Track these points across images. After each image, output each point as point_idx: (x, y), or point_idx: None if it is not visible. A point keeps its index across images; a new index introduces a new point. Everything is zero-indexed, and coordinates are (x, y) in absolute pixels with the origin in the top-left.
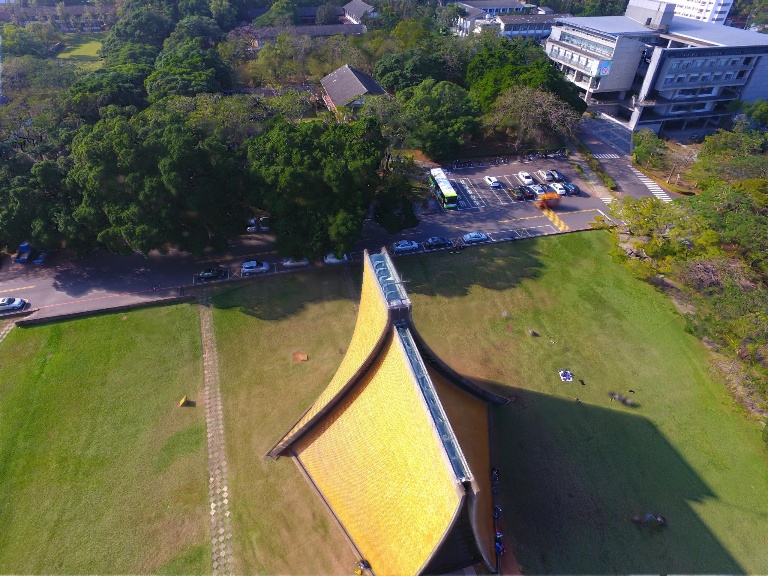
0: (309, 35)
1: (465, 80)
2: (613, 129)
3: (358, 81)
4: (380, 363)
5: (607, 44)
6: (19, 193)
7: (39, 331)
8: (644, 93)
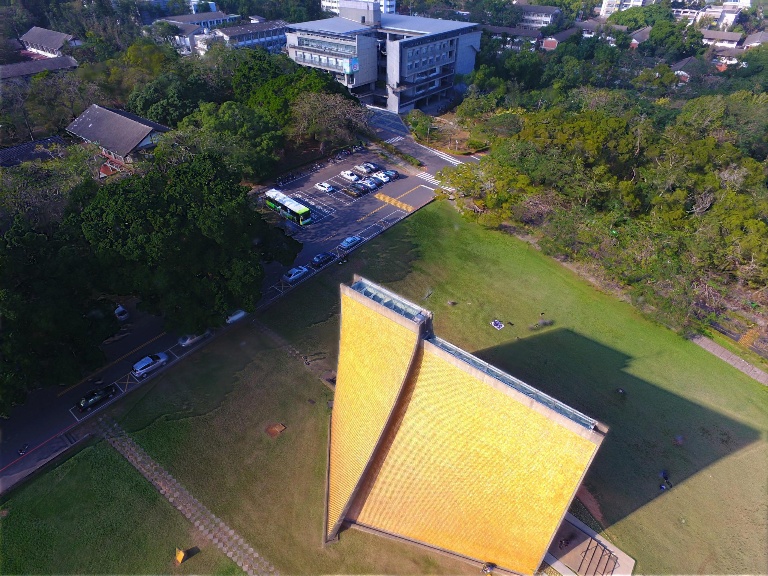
0: (20, 77)
1: (235, 97)
2: (383, 116)
3: (129, 120)
4: (413, 382)
5: (347, 43)
6: None
7: None
8: (395, 81)
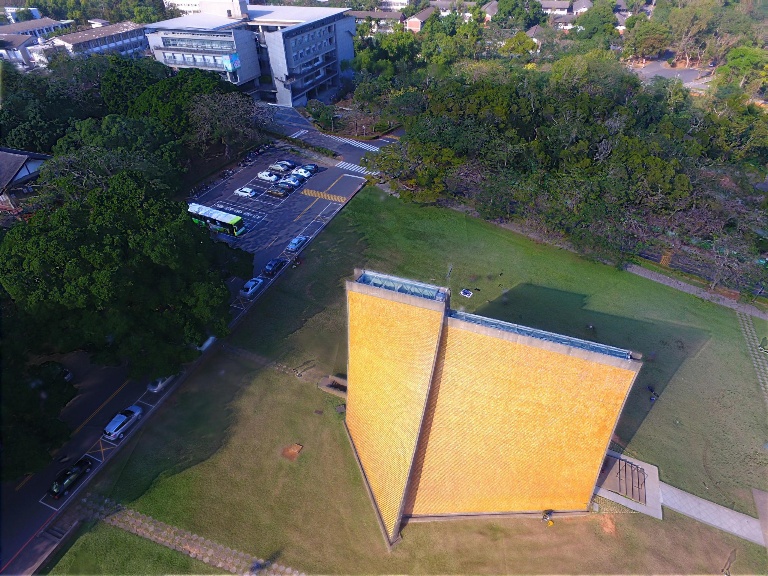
0: None
1: (109, 110)
2: (278, 111)
3: None
4: (441, 362)
5: (222, 39)
6: None
7: None
8: (283, 73)
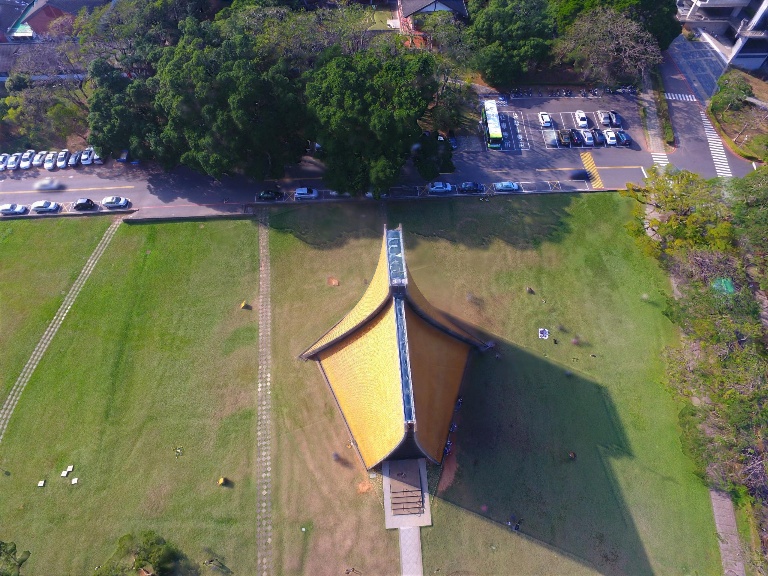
0: None
1: None
2: (706, 59)
3: None
4: (382, 316)
5: None
6: (119, 112)
7: (140, 229)
8: (755, 20)
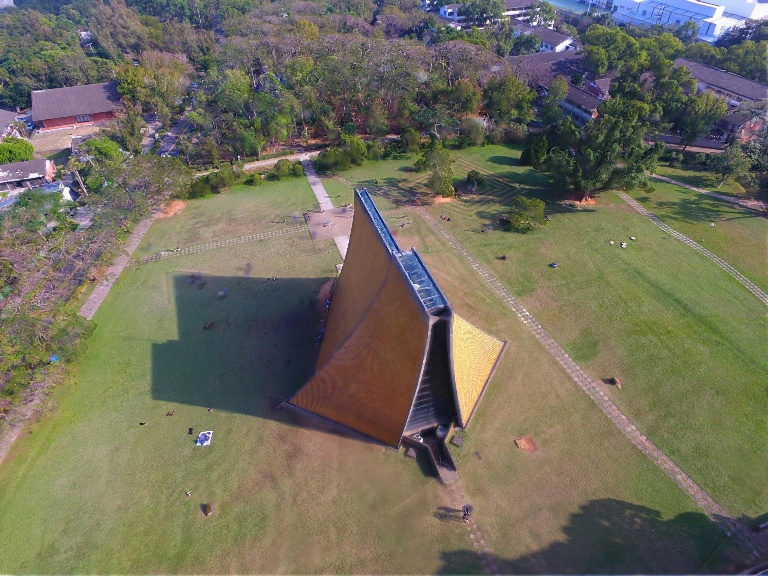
0: None
1: None
2: None
3: None
4: None
5: None
6: None
7: None
8: None
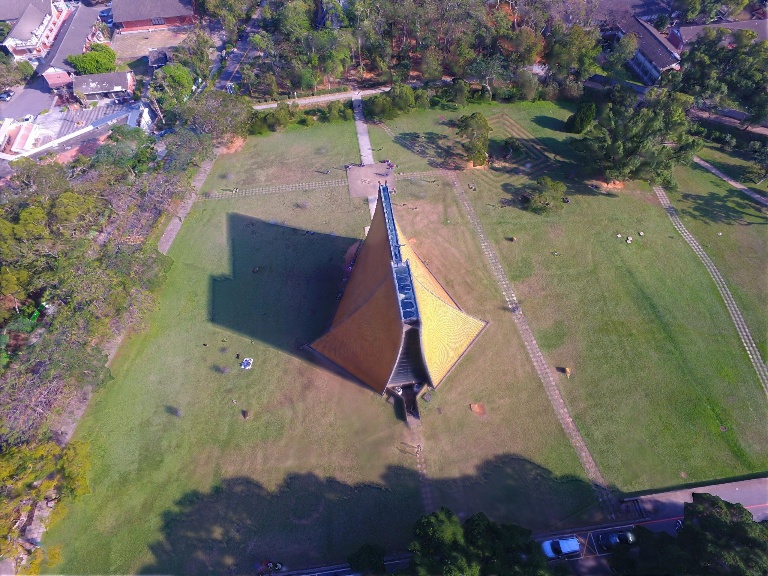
0: None
1: None
2: None
3: None
4: None
5: None
6: None
7: (764, 463)
8: None
